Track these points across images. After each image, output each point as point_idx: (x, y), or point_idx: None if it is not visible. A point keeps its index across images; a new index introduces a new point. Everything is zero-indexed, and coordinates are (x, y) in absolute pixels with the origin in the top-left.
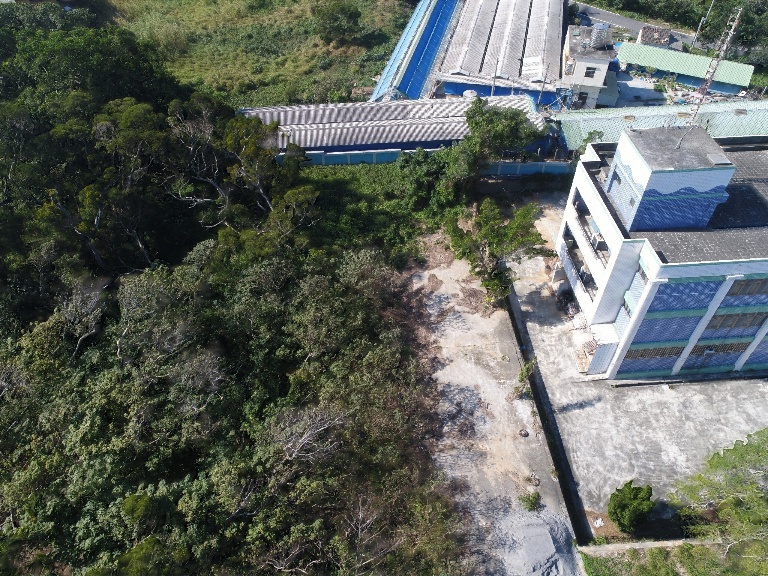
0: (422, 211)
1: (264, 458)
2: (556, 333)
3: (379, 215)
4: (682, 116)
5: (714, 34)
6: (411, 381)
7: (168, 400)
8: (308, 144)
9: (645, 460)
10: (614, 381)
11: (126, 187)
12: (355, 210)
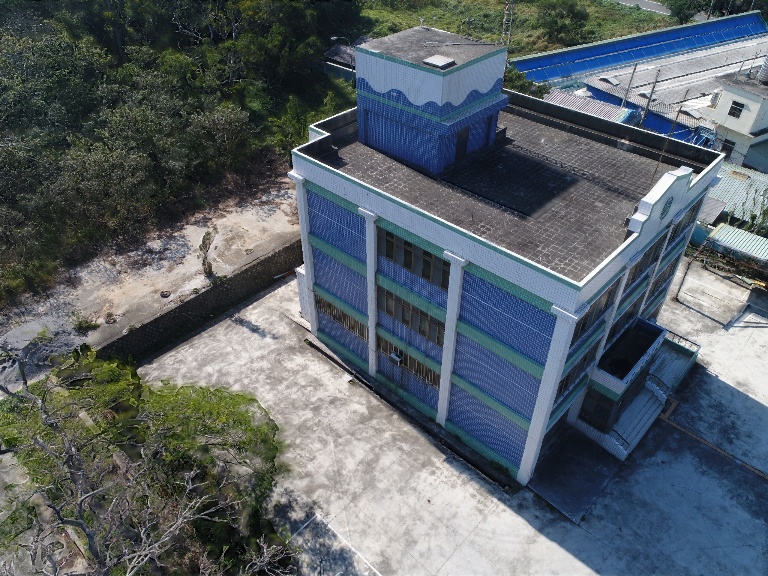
0: None
1: None
2: None
3: None
4: None
5: None
6: None
7: None
8: None
9: None
10: (314, 338)
11: (163, 8)
12: None
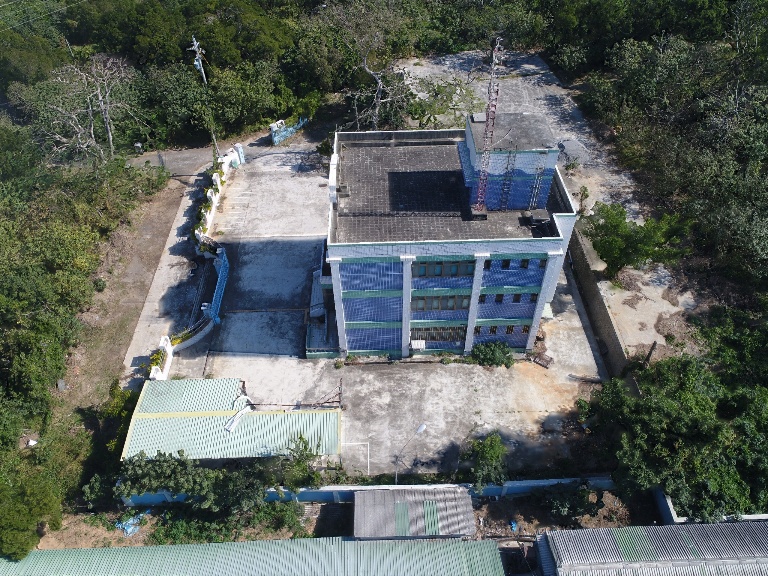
0: None
1: None
2: None
3: None
4: None
5: None
6: None
7: None
8: None
9: None
10: None
11: None
12: None
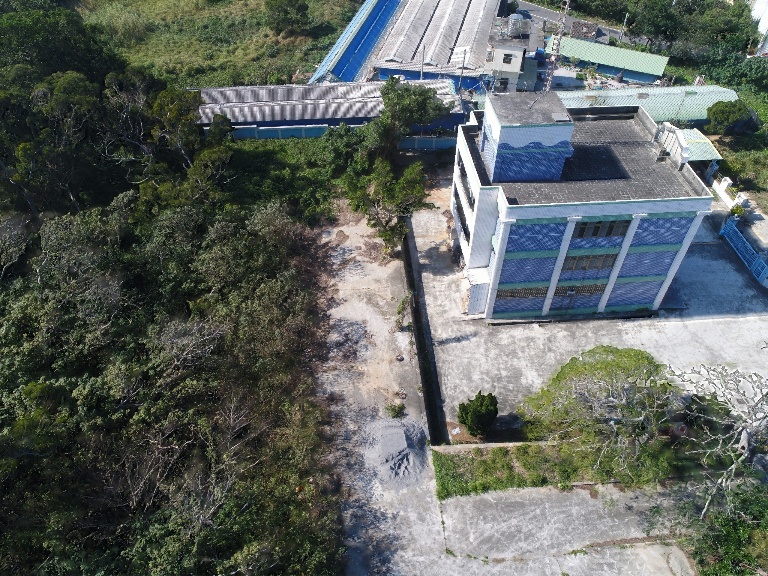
0: (340, 178)
1: (156, 364)
2: (447, 281)
3: (299, 180)
4: (589, 99)
5: (640, 29)
6: (296, 308)
7: (78, 317)
8: (242, 119)
9: (506, 383)
10: (491, 320)
11: (60, 146)
12: (278, 176)
